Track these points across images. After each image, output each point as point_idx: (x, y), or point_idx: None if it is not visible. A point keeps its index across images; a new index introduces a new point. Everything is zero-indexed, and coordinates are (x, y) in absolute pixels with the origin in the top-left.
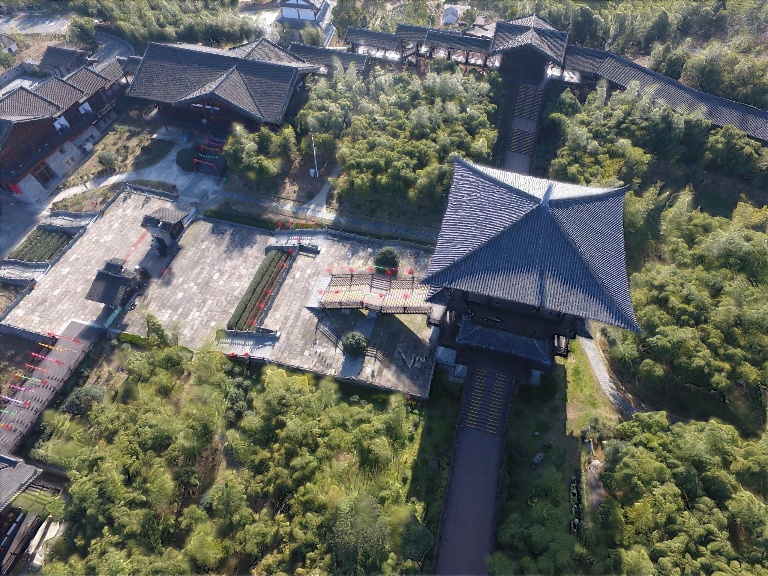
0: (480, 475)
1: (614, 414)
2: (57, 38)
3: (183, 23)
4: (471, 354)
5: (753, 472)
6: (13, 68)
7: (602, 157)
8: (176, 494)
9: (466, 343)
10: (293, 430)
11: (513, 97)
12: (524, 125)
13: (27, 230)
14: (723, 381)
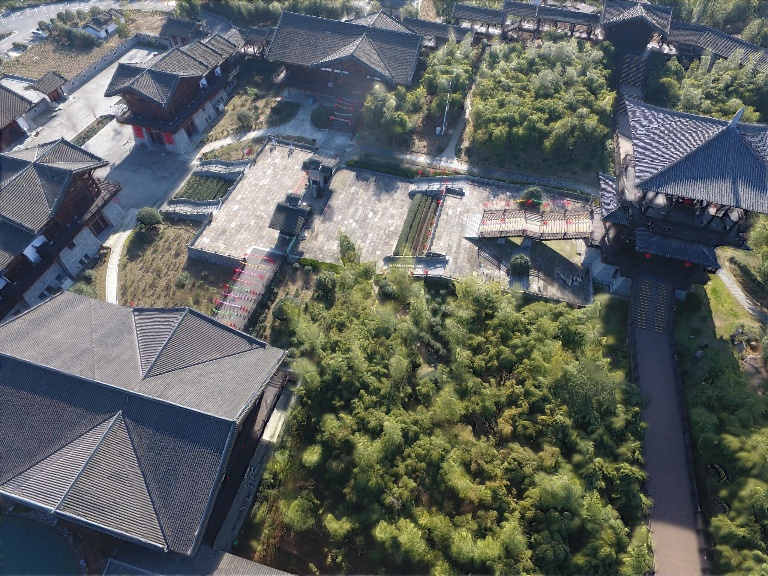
0: (657, 363)
1: (755, 323)
2: (158, 14)
3: (287, 0)
4: (634, 269)
5: None
6: (131, 38)
7: (716, 114)
8: (408, 370)
9: (645, 251)
10: (504, 319)
11: (618, 66)
12: (630, 91)
13: (183, 176)
14: None
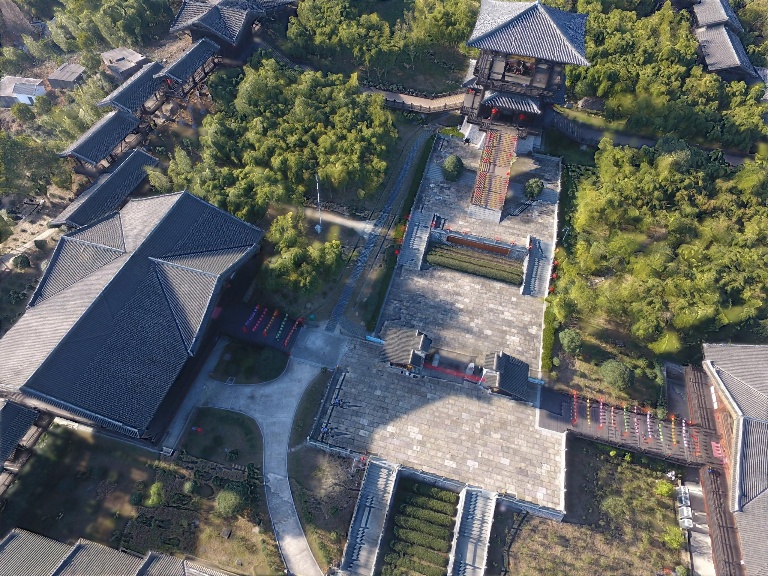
0: (606, 137)
1: None
2: None
3: None
4: None
5: None
6: None
7: (372, 33)
8: None
9: None
10: (631, 190)
11: None
12: None
13: None
14: None
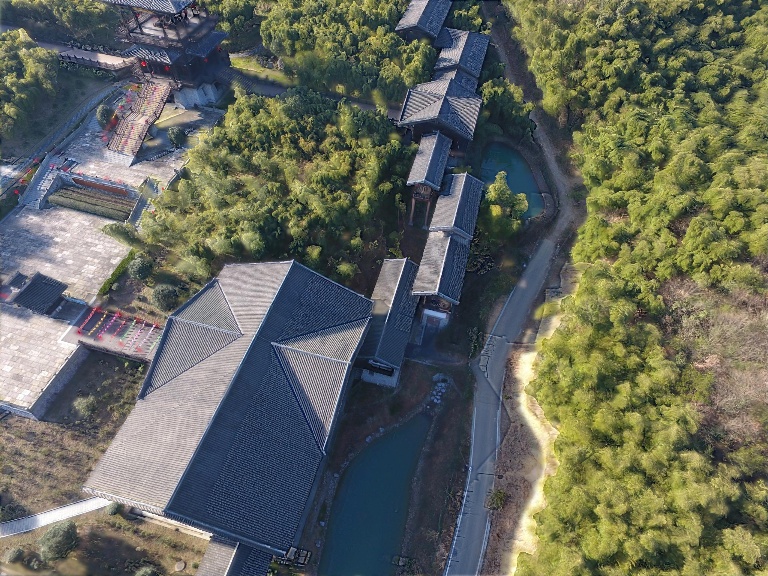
0: (276, 92)
1: (256, 56)
2: None
3: None
4: None
5: (293, 5)
6: None
7: None
8: None
9: None
10: (235, 133)
11: None
12: (1, 30)
13: None
14: (253, 2)
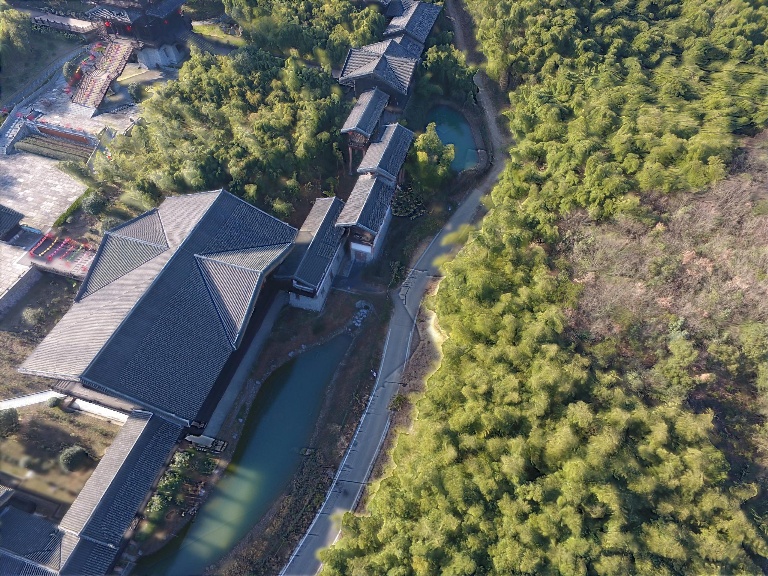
0: None
1: (220, 24)
2: None
3: None
4: None
5: None
6: None
7: None
8: None
9: (165, 16)
10: (187, 86)
11: None
12: None
13: None
14: None
